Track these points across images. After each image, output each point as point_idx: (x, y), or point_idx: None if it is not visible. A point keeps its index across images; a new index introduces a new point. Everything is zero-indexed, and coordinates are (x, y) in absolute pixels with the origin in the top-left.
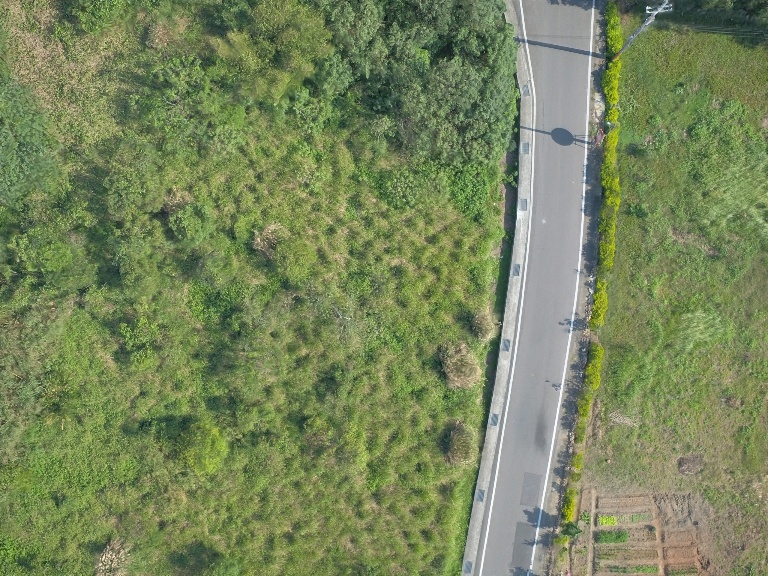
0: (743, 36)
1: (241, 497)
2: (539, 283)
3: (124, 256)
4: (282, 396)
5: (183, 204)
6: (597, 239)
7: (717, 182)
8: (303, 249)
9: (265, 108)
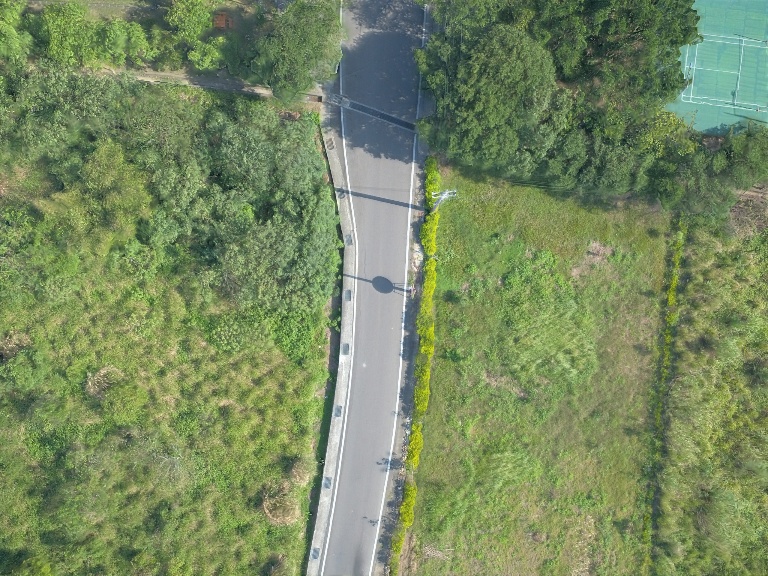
0: (554, 190)
1: None
2: (359, 424)
3: None
4: (114, 531)
5: (16, 349)
6: (414, 383)
7: (528, 329)
8: (131, 394)
9: None
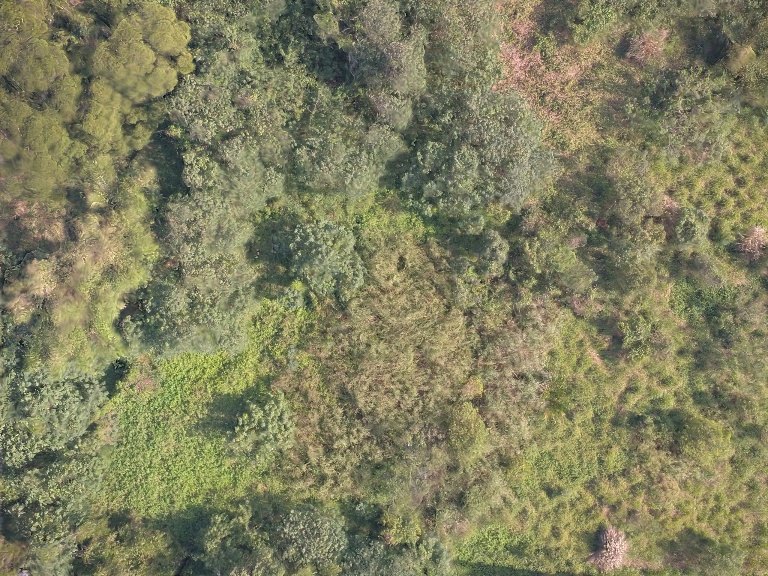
0: None
1: (730, 486)
2: None
3: (639, 258)
4: (767, 390)
5: (679, 208)
6: None
7: None
8: None
9: (743, 116)
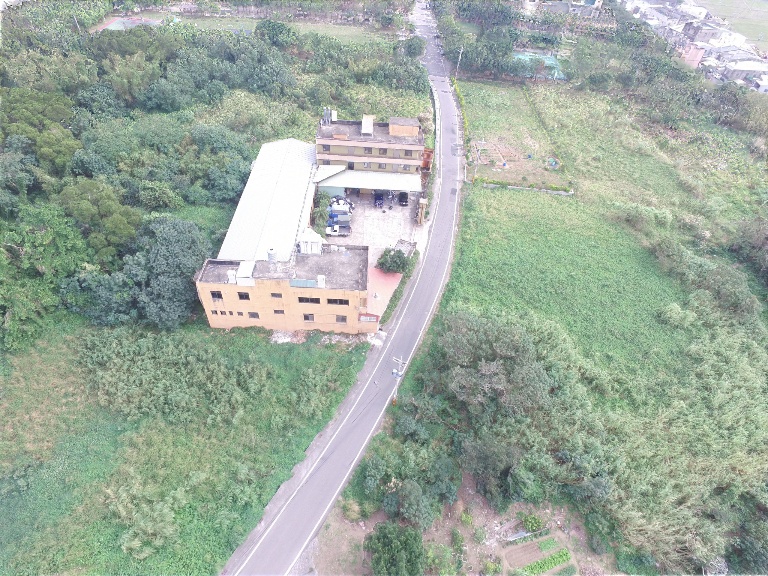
0: (487, 84)
1: None
2: (445, 110)
3: None
4: None
5: None
6: None
7: None
8: None
9: None
